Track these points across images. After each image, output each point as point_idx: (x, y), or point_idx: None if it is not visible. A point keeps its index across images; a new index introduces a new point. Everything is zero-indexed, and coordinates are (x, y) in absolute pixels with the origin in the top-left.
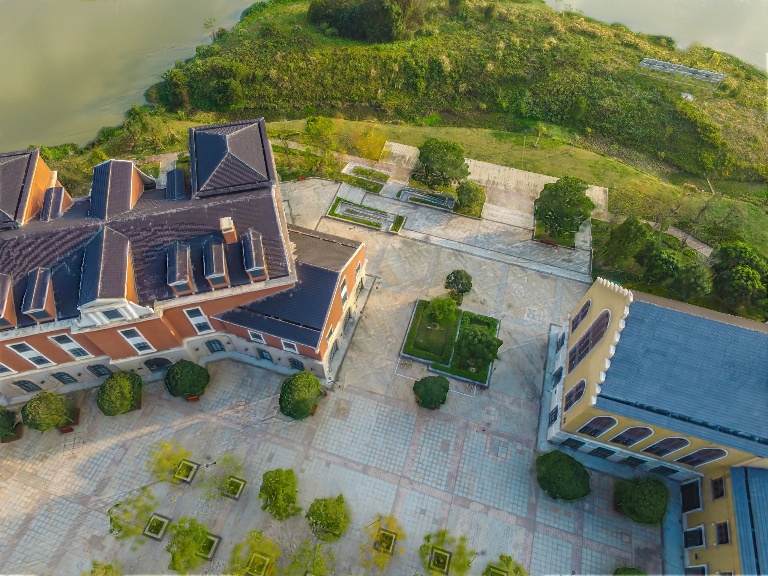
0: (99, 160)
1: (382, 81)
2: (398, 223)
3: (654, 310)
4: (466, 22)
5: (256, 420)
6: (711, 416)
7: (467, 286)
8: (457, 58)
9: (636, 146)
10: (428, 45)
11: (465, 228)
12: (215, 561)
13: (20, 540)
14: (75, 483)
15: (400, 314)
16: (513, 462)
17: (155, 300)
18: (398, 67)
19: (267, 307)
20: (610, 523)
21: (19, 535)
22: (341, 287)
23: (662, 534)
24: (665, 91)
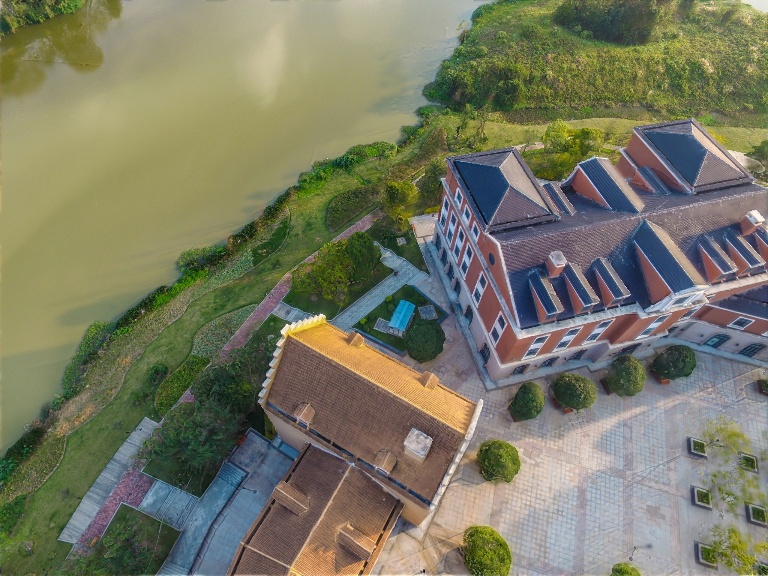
0: None
1: (648, 82)
2: None
3: None
4: (704, 25)
5: (731, 401)
6: None
7: None
8: (713, 60)
9: None
10: (678, 47)
11: None
12: None
13: (586, 510)
14: (603, 458)
15: None
16: None
17: None
18: (662, 69)
19: (764, 295)
20: None
21: (582, 505)
22: None
23: None
24: None
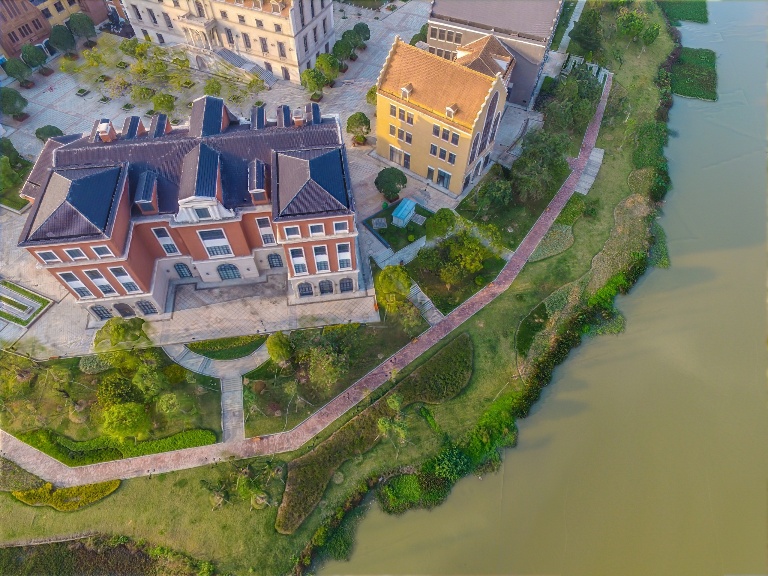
0: None
1: None
2: None
3: None
4: None
5: None
6: None
7: None
8: None
9: None
10: None
11: None
12: None
13: None
14: None
15: None
16: (36, 126)
17: None
18: None
19: None
20: None
21: None
22: None
23: None
24: None
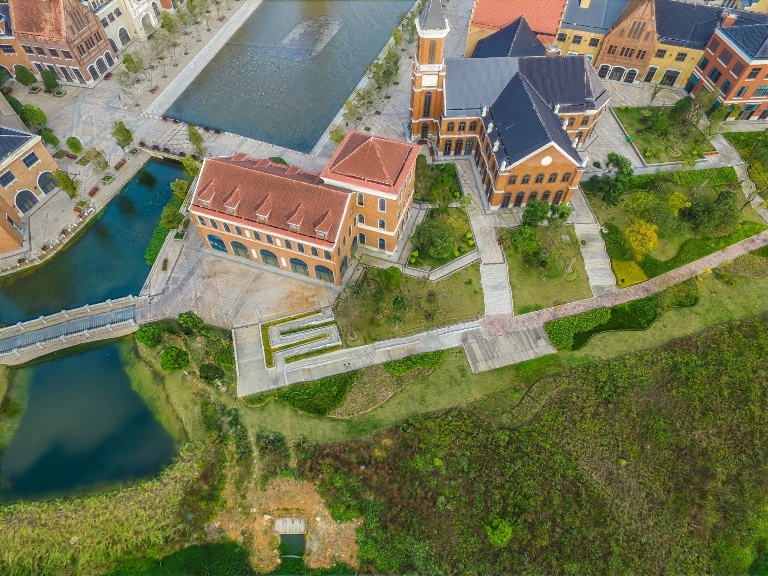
0: None
1: None
2: None
3: None
4: None
5: None
6: None
7: None
8: None
9: None
10: None
11: None
12: None
13: None
14: None
15: None
16: None
17: None
18: None
19: None
20: None
21: None
22: None
23: None
24: None
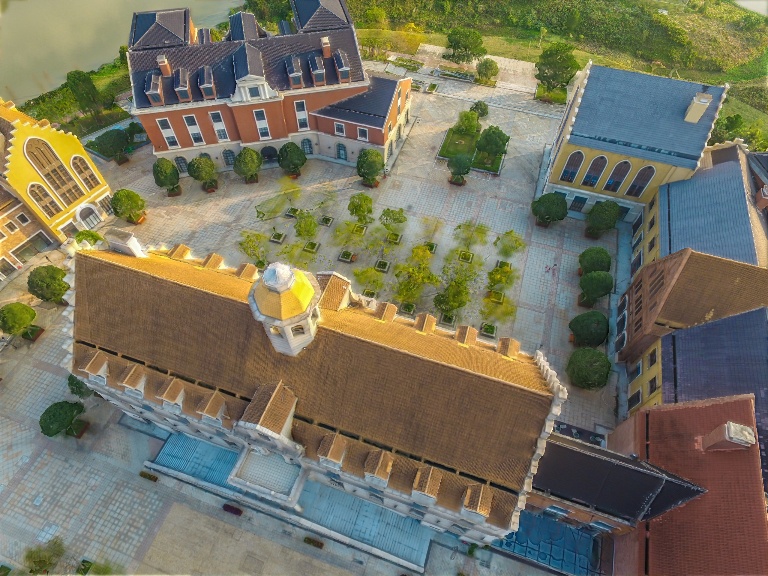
0: (214, 37)
1: (416, 3)
2: (432, 88)
3: (605, 71)
4: None
5: (338, 189)
6: (643, 140)
7: (485, 111)
8: None
9: (619, 48)
10: None
11: (483, 92)
12: (318, 254)
13: (190, 242)
14: (221, 217)
15: (435, 137)
16: (516, 213)
17: (278, 91)
18: None
19: (348, 104)
20: (582, 243)
21: (189, 239)
22: (398, 95)
23: (617, 249)
24: (644, 7)
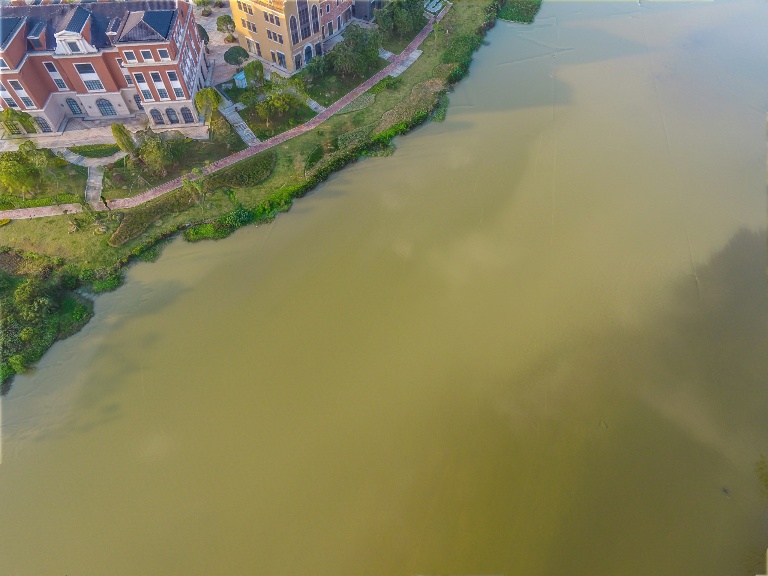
0: None
1: None
2: None
3: None
4: None
5: None
6: None
7: None
8: None
9: None
10: None
11: None
12: None
13: None
14: None
15: None
16: None
17: None
18: None
19: None
20: None
21: None
22: None
23: None
24: None
